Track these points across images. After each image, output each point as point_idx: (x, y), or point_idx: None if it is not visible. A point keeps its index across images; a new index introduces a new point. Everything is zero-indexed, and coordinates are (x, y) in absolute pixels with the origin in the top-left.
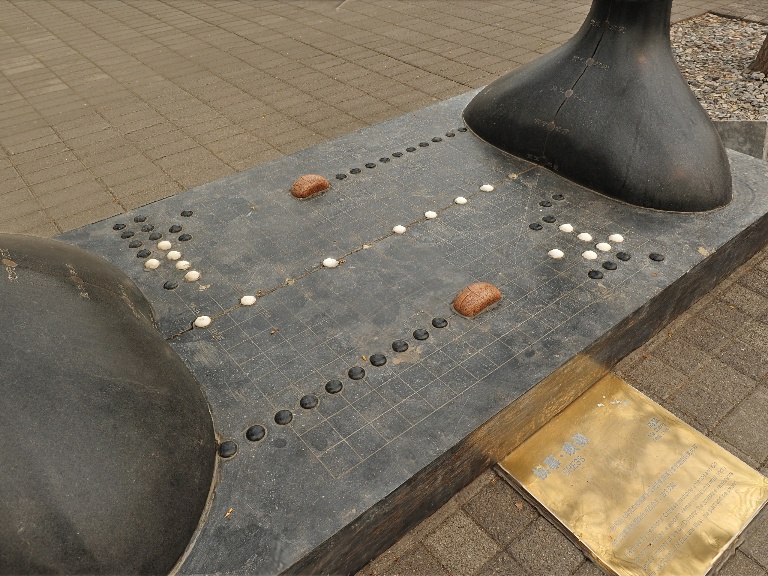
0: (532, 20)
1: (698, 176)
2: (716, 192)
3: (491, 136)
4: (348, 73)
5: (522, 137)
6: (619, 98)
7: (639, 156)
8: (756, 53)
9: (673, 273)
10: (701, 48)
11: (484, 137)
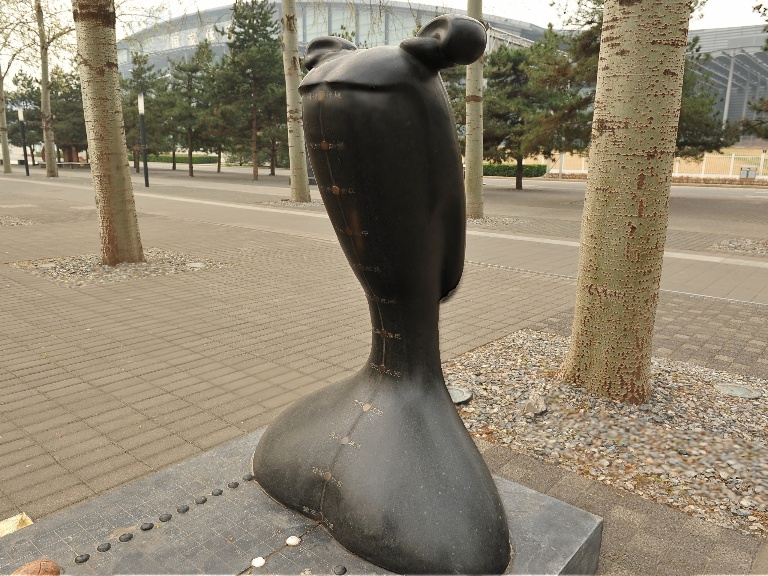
0: None
1: None
2: None
3: None
4: None
5: None
6: None
7: None
8: None
9: None
10: None
11: None
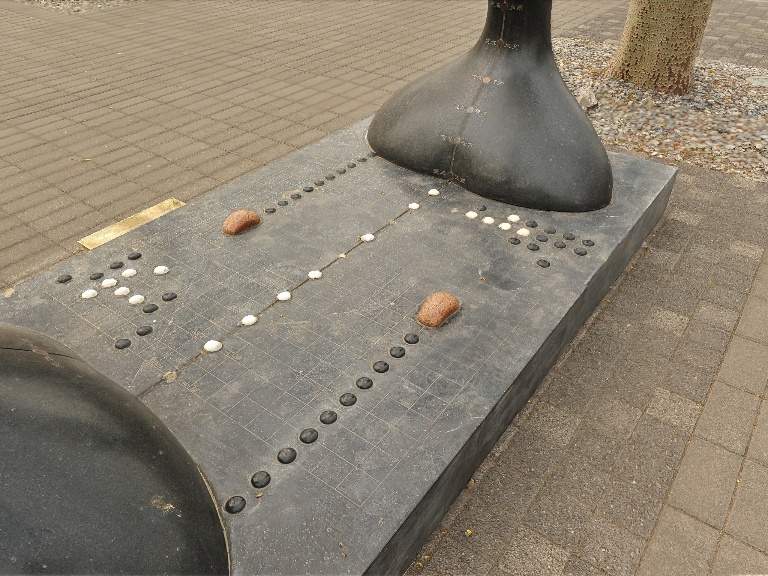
0: None
1: None
2: None
3: None
4: None
5: None
6: None
7: None
8: None
9: (62, 267)
10: None
11: None
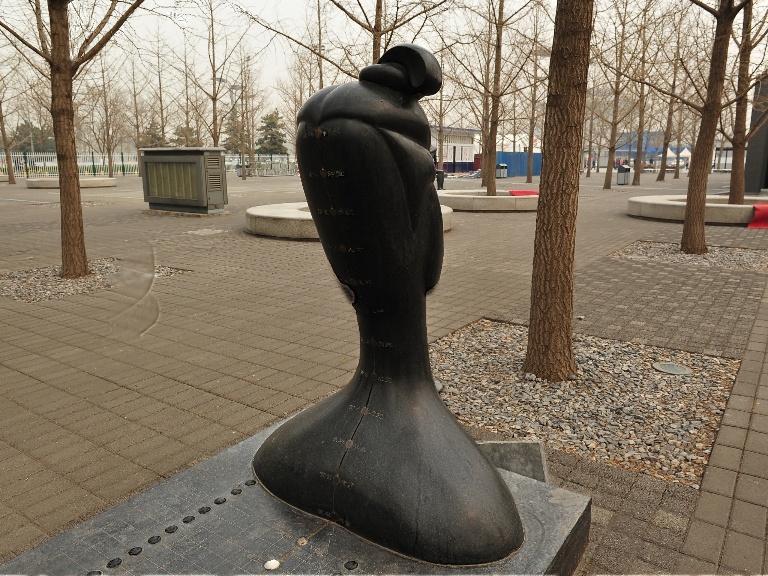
0: (333, 335)
1: (485, 522)
2: (506, 536)
3: (279, 490)
4: (141, 410)
5: (310, 492)
6: (397, 447)
7: (425, 508)
8: (525, 354)
9: None
10: (481, 352)
11: (273, 491)
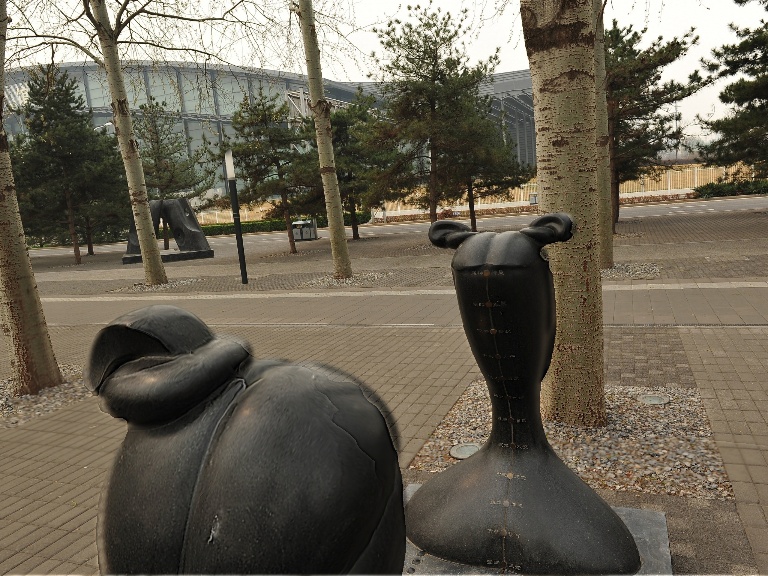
0: None
1: None
2: None
3: None
4: None
5: None
6: None
7: None
8: None
9: None
10: None
11: None
